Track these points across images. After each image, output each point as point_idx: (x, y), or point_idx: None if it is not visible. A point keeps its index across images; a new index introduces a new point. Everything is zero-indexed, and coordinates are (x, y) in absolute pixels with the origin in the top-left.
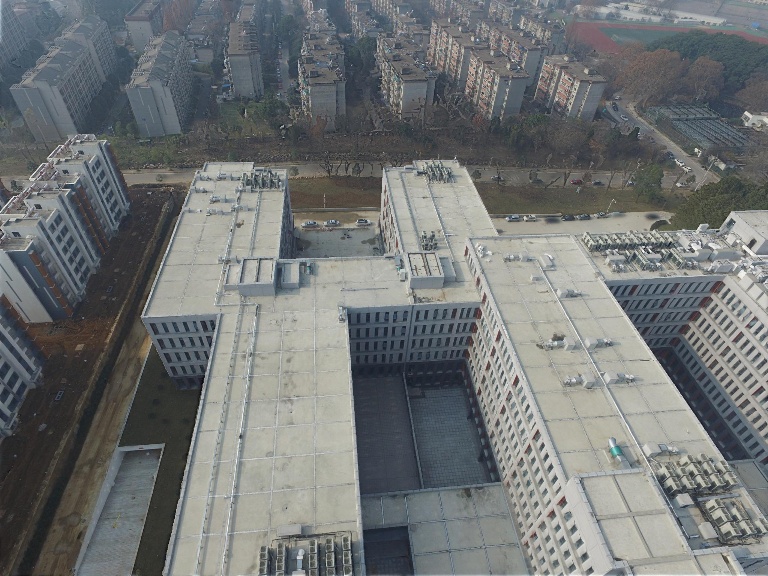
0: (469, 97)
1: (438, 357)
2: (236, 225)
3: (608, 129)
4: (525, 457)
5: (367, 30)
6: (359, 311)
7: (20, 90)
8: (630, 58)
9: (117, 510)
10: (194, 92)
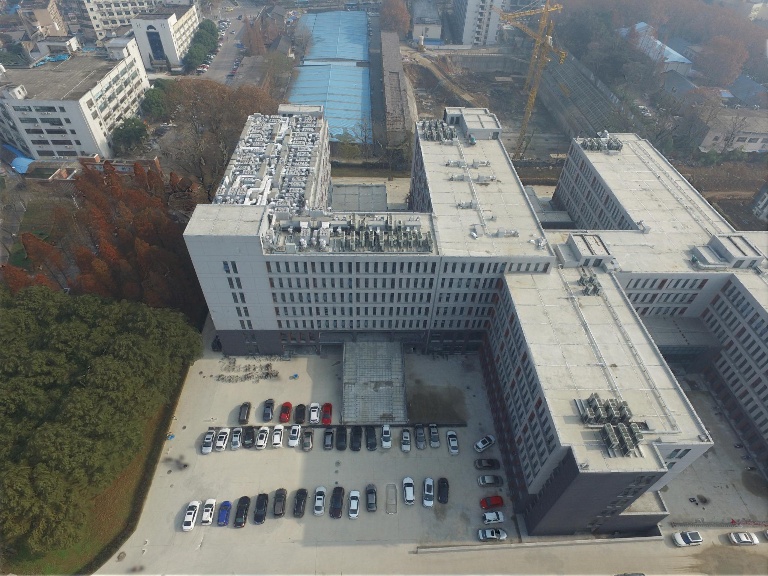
0: None
1: None
2: None
3: None
4: None
5: None
6: None
7: None
8: None
9: None
10: None
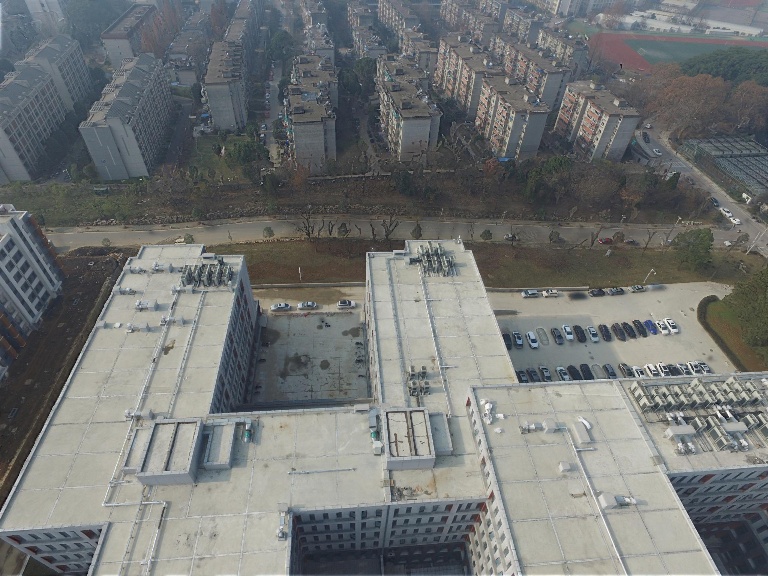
0: (480, 129)
1: (428, 539)
2: (163, 349)
3: (642, 173)
4: None
5: (368, 48)
6: (311, 512)
7: None
8: (664, 82)
9: None
10: (171, 121)
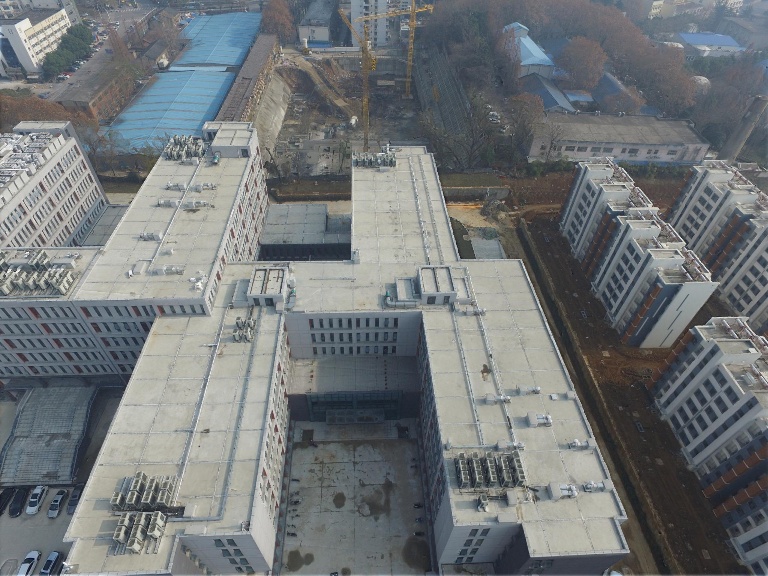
0: None
1: None
2: (490, 370)
3: None
4: None
5: None
6: None
7: None
8: None
9: None
10: None
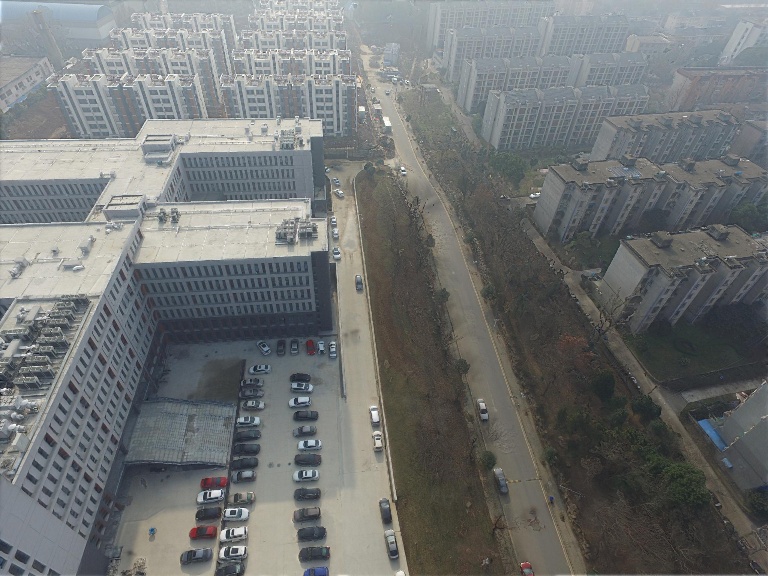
0: None
1: None
2: (231, 137)
3: None
4: None
5: None
6: None
7: None
8: None
9: None
10: None
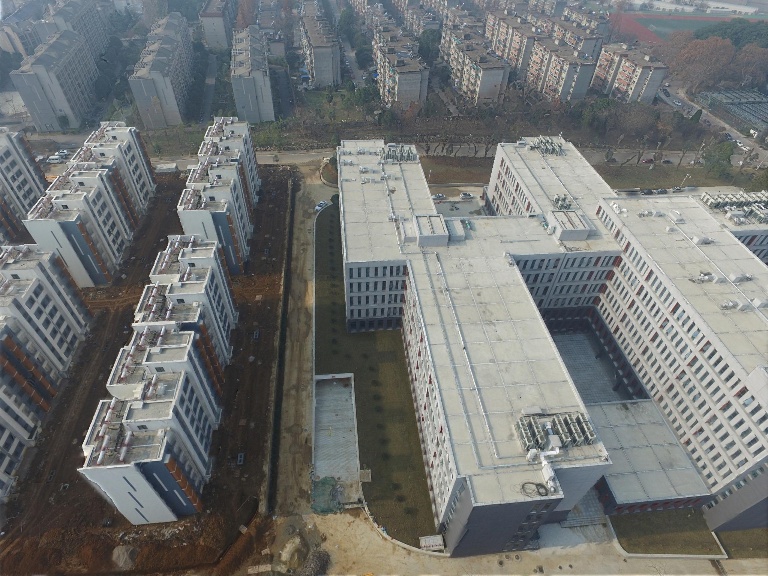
0: (533, 84)
1: (571, 304)
2: (390, 191)
3: (671, 112)
4: (688, 368)
5: (425, 23)
6: (521, 258)
7: (137, 81)
8: (680, 46)
9: (327, 424)
10: (273, 83)
